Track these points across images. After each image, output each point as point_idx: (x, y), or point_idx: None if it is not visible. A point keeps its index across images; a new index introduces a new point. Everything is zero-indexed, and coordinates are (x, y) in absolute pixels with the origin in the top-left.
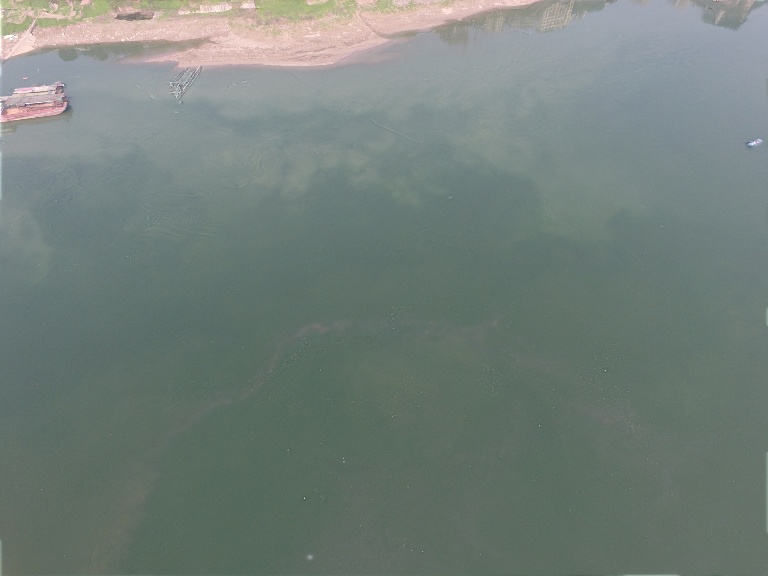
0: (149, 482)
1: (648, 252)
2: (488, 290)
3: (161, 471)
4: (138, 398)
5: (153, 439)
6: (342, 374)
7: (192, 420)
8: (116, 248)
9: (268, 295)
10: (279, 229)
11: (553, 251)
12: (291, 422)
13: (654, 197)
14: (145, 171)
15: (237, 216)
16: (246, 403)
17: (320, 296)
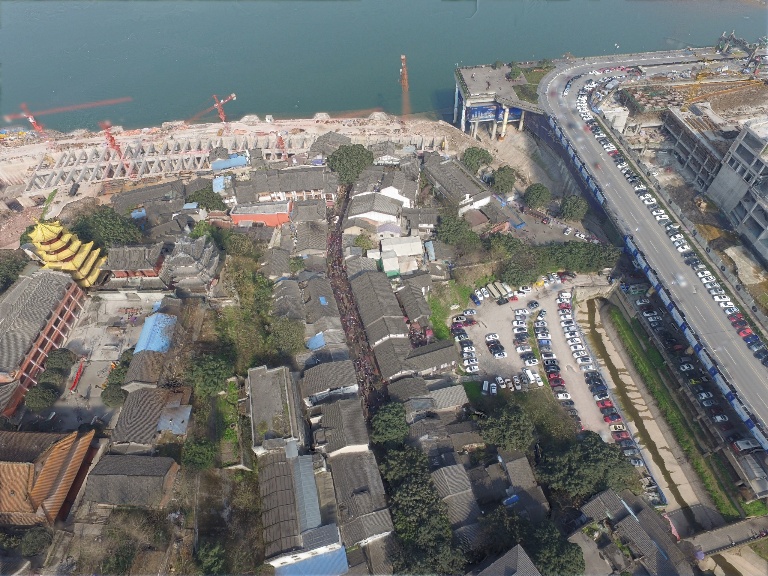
0: (1, 77)
1: (280, 18)
2: (187, 31)
3: (7, 75)
4: (3, 61)
5: (6, 69)
6: (98, 53)
7: (25, 64)
8: (9, 27)
9: (76, 34)
10: (91, 14)
11: (228, 17)
12: (68, 63)
13: (303, 1)
14: (32, 0)
15: (73, 12)
16: (49, 58)
17: (103, 36)
